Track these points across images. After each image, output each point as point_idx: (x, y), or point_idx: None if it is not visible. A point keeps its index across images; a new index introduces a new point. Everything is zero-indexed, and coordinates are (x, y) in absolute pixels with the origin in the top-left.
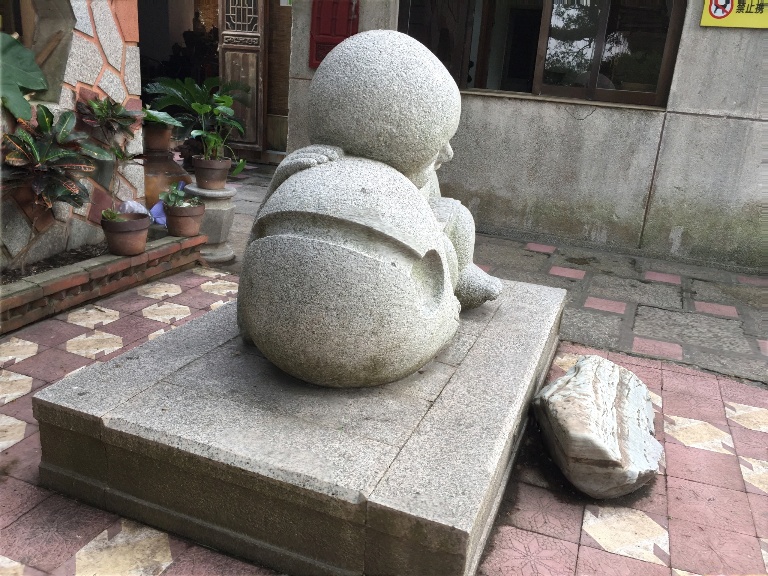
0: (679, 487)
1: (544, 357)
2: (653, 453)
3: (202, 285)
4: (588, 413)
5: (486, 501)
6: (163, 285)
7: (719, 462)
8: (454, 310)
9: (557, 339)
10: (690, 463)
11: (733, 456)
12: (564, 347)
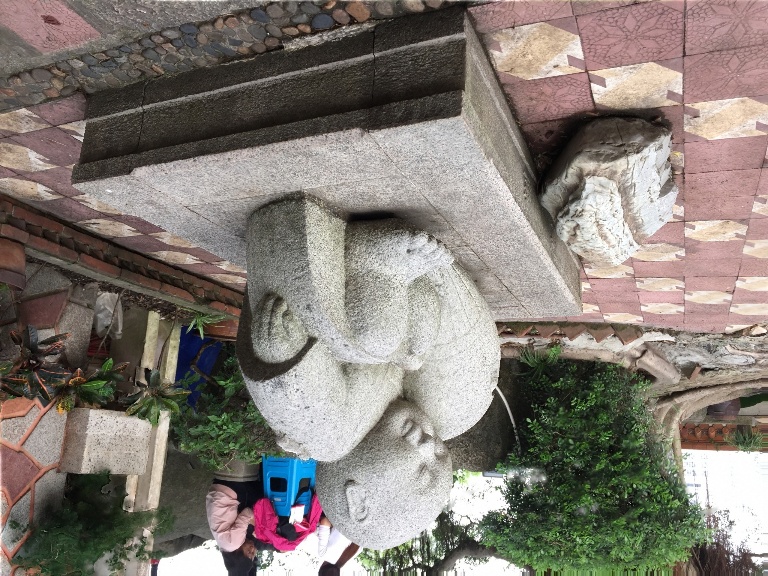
0: (695, 180)
1: (512, 162)
2: (667, 211)
3: (4, 166)
4: (608, 256)
5: (577, 297)
6: (3, 184)
7: (744, 148)
8: (479, 318)
9: (476, 59)
10: (710, 158)
11: (764, 137)
12: (483, 19)
